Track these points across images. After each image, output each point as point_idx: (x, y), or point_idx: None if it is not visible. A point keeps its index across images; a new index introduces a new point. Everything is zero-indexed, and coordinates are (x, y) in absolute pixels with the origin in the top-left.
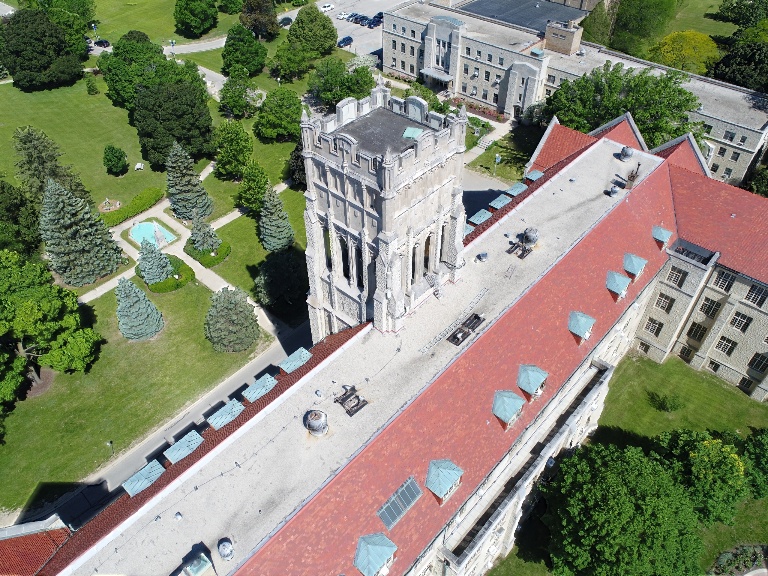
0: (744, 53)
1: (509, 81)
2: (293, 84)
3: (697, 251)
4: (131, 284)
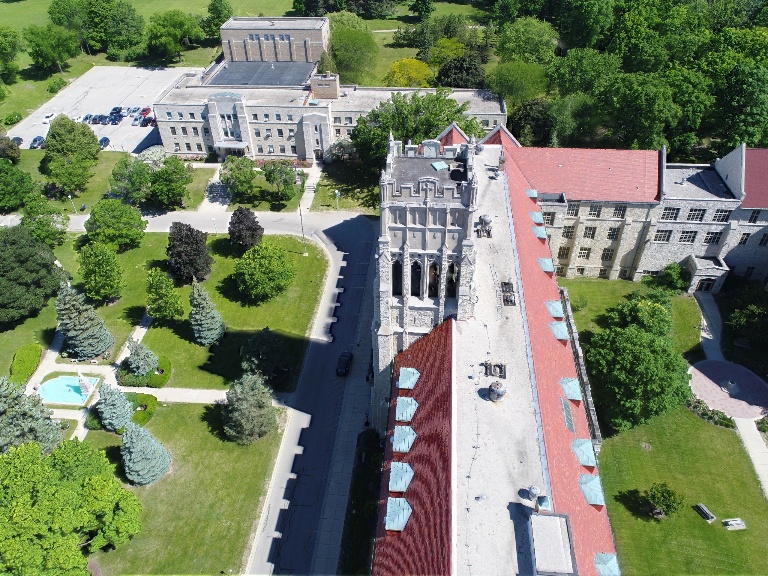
0: (455, 65)
1: (304, 132)
2: (80, 198)
3: (551, 197)
4: None
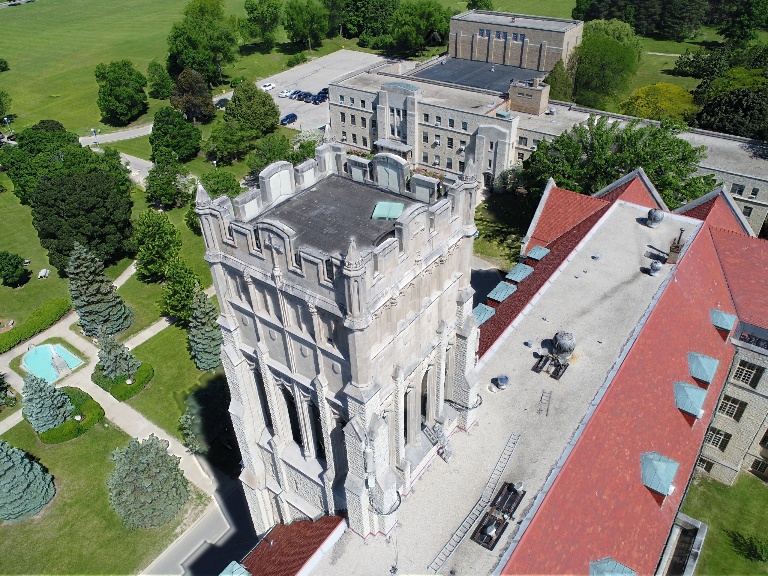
0: (729, 100)
1: (476, 146)
2: (232, 167)
3: None
4: (1, 444)
